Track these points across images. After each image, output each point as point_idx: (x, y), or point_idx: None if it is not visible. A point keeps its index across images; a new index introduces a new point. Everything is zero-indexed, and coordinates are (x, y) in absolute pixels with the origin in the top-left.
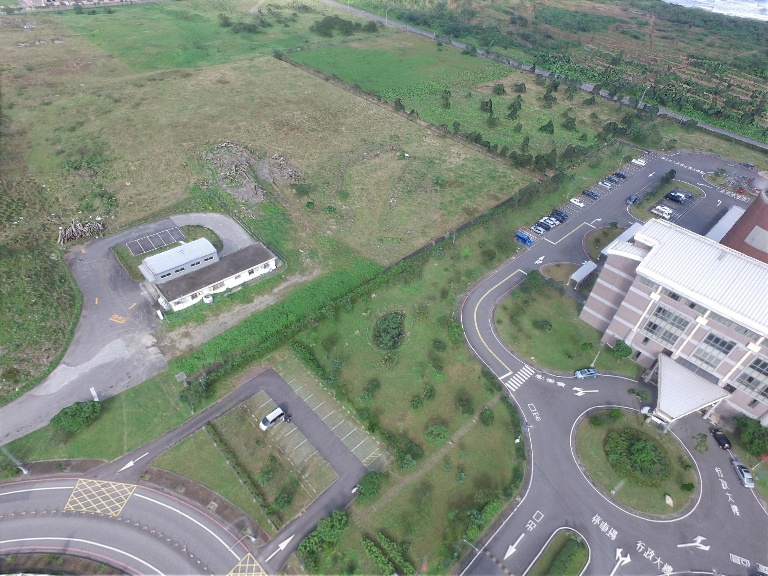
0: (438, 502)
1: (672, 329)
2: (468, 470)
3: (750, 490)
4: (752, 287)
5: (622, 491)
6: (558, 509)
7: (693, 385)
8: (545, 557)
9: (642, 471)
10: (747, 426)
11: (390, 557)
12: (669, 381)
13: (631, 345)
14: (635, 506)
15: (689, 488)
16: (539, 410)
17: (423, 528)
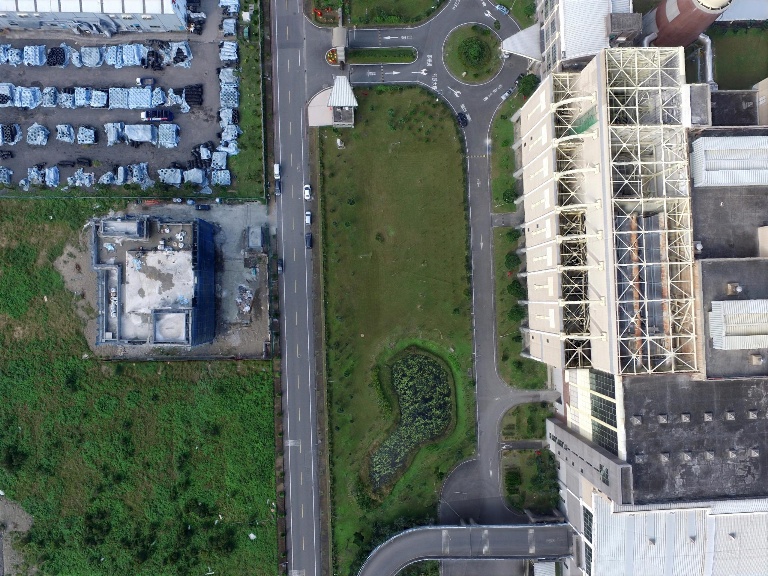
0: (378, 2)
1: (549, 8)
2: (401, 1)
3: (502, 100)
4: (586, 2)
5: (451, 57)
6: (420, 42)
7: (531, 44)
8: (397, 49)
9: (467, 57)
10: (528, 76)
11: (344, 3)
12: (523, 34)
13: (538, 12)
14: (449, 65)
15: (475, 75)
16: (459, 5)
17: (364, 5)
